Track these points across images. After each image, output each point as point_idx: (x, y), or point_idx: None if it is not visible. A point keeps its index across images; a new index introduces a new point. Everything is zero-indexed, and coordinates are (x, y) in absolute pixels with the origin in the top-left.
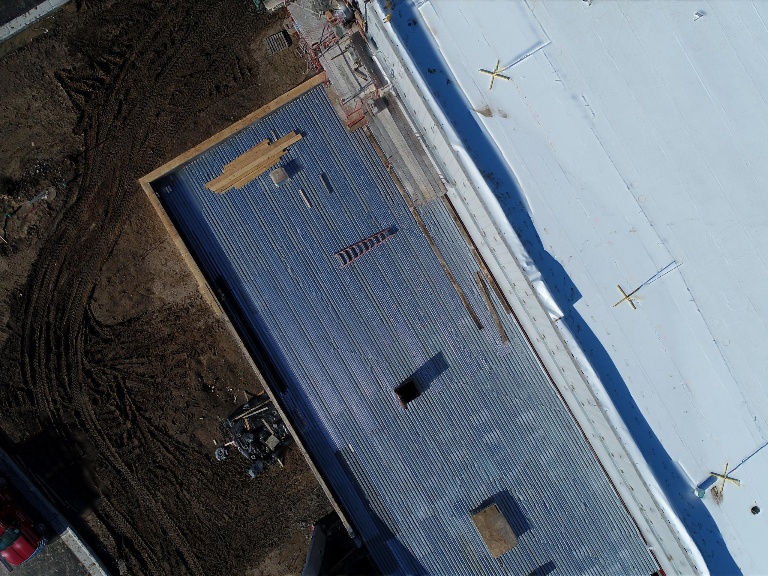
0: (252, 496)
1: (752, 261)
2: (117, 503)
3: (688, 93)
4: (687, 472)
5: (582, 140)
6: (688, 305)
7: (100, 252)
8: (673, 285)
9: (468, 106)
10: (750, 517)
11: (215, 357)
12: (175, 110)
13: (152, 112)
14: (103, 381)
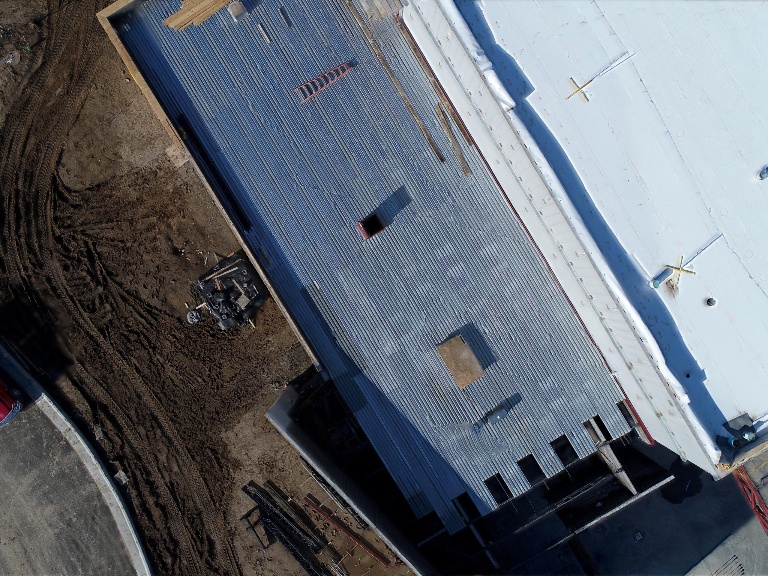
0: (225, 358)
1: (705, 50)
2: (91, 368)
3: None
4: (642, 265)
5: None
6: (641, 96)
7: (66, 117)
8: (626, 76)
9: None
10: (706, 309)
11: (184, 220)
12: None
13: None
14: (73, 247)
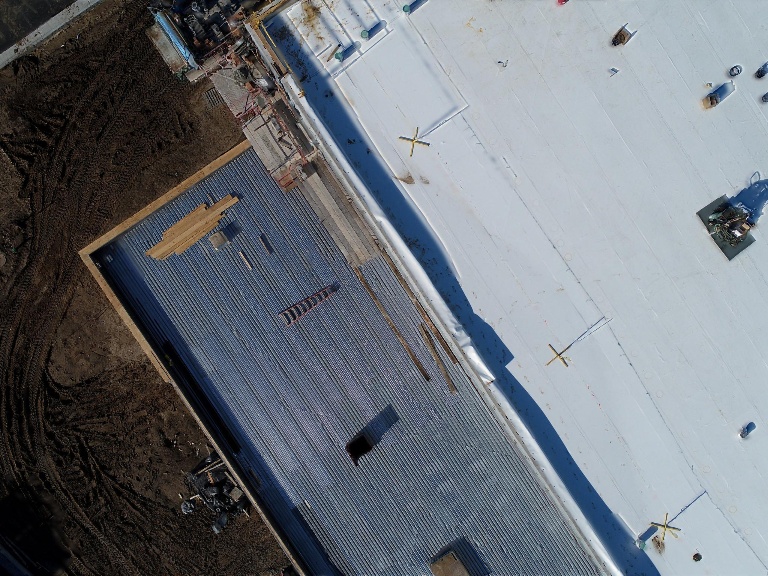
0: (220, 547)
1: (681, 313)
2: (88, 561)
3: (608, 149)
4: (628, 524)
5: (505, 202)
6: (620, 360)
7: (54, 315)
8: (604, 341)
9: (390, 174)
10: (692, 564)
11: (175, 412)
12: (119, 169)
13: (96, 173)
14: (66, 442)
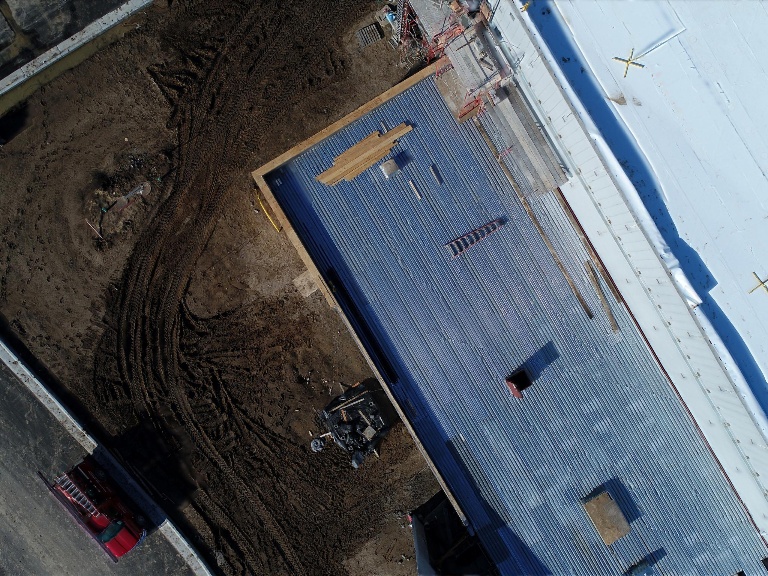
0: (348, 487)
1: None
2: (214, 495)
3: None
4: None
5: (717, 127)
6: None
7: (194, 246)
8: None
9: (602, 94)
10: None
11: (310, 349)
12: (268, 104)
13: (245, 106)
14: (199, 374)
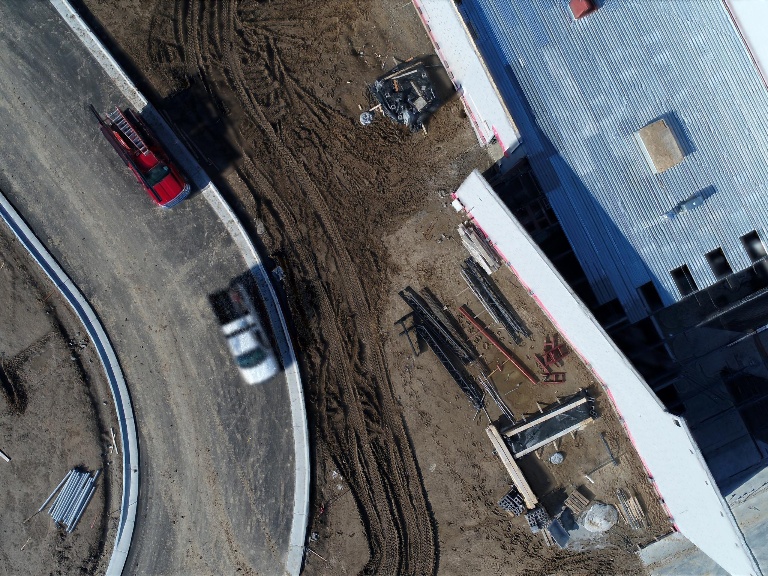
0: (393, 163)
1: None
2: (259, 162)
3: None
4: None
5: None
6: None
7: None
8: None
9: None
10: None
11: (366, 22)
12: None
13: None
14: (254, 41)
